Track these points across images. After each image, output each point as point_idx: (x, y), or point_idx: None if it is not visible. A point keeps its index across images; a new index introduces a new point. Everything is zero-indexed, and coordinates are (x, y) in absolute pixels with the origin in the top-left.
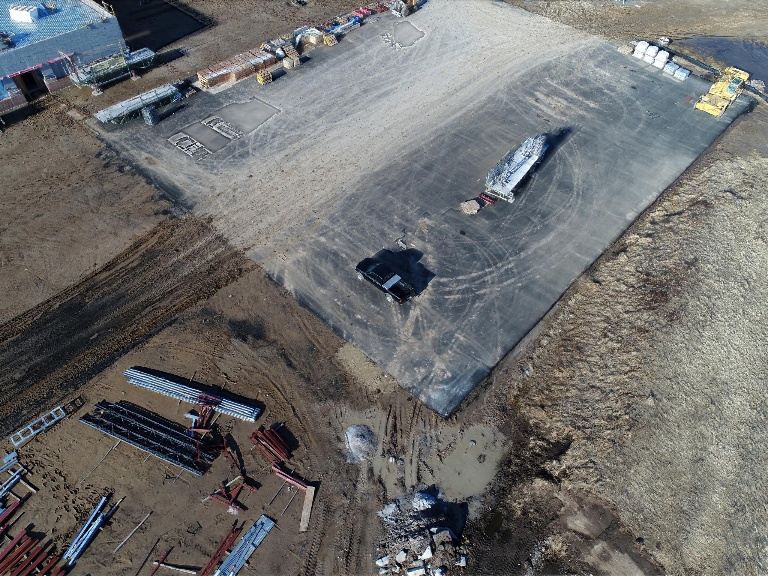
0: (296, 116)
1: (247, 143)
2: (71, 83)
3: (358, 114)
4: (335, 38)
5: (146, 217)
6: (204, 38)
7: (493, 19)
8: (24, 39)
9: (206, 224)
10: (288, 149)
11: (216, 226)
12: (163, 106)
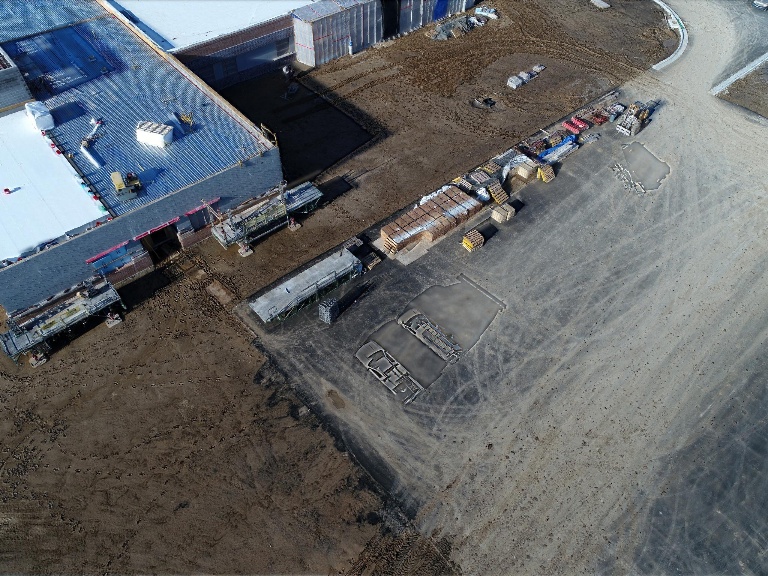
0: (530, 318)
1: (471, 371)
2: (210, 233)
3: (620, 321)
4: (552, 171)
5: (344, 526)
6: (374, 158)
7: (756, 146)
8: (157, 180)
9: (442, 557)
10: (534, 389)
11: (459, 563)
12: (339, 285)
